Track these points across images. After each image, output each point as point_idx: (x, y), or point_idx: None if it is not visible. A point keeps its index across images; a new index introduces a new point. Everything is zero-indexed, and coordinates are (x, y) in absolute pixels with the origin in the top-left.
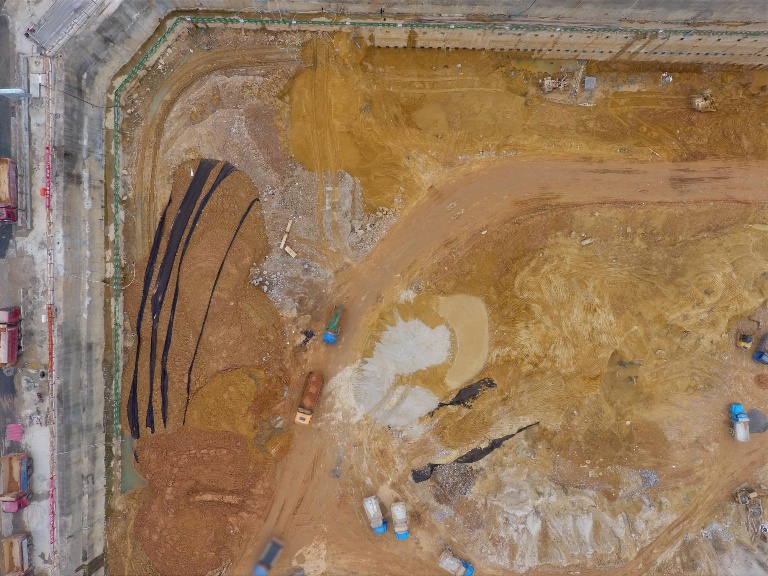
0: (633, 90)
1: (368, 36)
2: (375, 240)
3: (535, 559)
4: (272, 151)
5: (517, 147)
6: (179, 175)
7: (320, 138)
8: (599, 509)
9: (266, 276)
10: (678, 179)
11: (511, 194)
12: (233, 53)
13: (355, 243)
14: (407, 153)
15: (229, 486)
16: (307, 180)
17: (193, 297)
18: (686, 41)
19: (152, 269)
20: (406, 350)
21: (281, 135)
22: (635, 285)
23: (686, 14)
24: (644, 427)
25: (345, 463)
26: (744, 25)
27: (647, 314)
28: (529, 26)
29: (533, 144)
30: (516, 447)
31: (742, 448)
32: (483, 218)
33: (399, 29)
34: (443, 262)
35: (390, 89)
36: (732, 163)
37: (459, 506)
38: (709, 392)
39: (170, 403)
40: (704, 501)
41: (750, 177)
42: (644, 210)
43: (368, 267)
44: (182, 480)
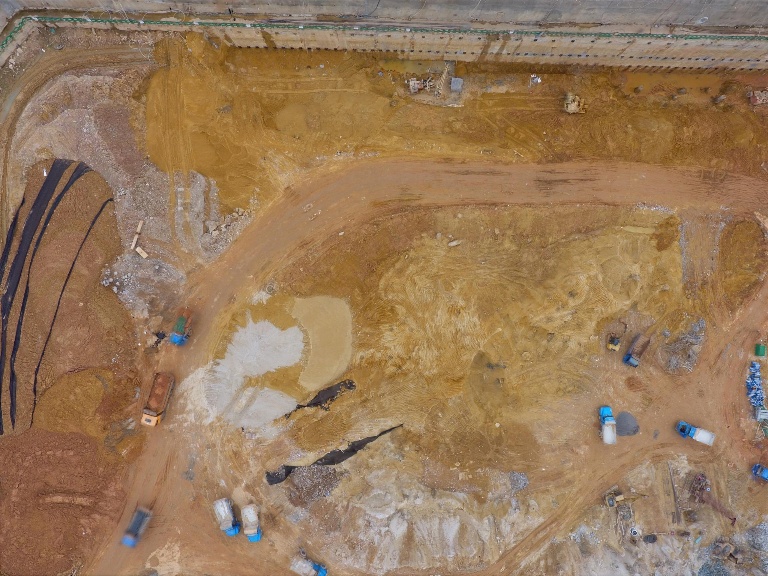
0: (502, 91)
1: (223, 36)
2: (228, 241)
3: (395, 562)
4: (127, 151)
5: (376, 148)
6: (32, 175)
7: (172, 138)
8: (466, 512)
9: (117, 277)
10: (543, 181)
11: (370, 195)
12: (86, 53)
13: (209, 244)
14: (263, 154)
15: (80, 488)
16: (158, 181)
17: (42, 298)
18: (541, 42)
19: (3, 269)
20: (251, 352)
21: (137, 135)
22: (505, 287)
23: (535, 15)
24: (514, 429)
25: (198, 465)
26: (596, 26)
27: (513, 316)
28: (380, 27)
29: (392, 145)
30: (382, 449)
31: (612, 451)
32: (340, 219)
33: (249, 29)
34: (298, 263)
35: (252, 89)
36: (598, 165)
37: (316, 508)
38: (579, 394)
39: (18, 404)
40: (574, 504)
41: (617, 179)
42: (509, 212)
43: (220, 268)
44: (29, 482)
